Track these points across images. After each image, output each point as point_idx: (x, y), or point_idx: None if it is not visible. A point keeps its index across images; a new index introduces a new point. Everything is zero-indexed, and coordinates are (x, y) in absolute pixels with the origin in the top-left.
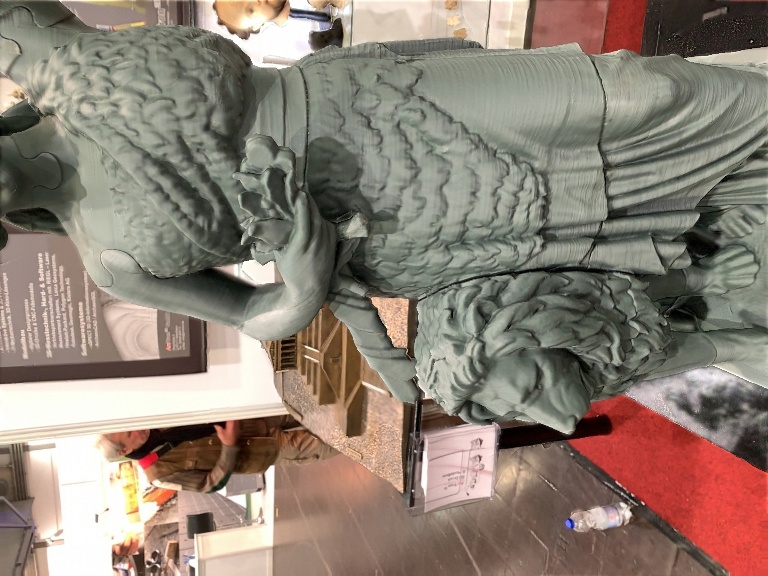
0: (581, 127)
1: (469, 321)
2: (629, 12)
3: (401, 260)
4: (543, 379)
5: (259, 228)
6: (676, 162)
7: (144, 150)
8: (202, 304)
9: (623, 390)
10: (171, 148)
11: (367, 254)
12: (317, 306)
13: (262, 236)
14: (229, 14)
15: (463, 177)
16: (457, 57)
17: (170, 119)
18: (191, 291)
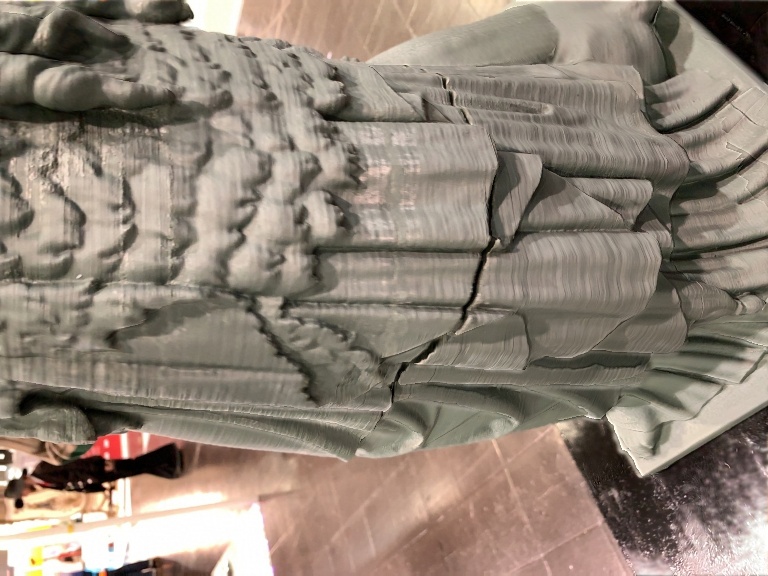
0: None
1: None
2: None
3: None
4: None
5: None
6: None
7: None
8: None
9: None
10: None
11: None
12: None
13: None
14: None
15: None
16: (205, 434)
17: None
18: None
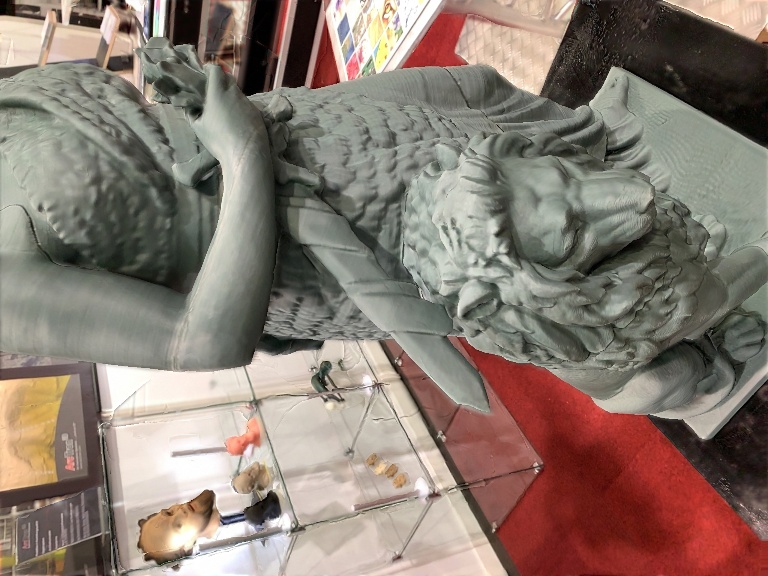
0: (441, 84)
1: (443, 150)
2: (515, 386)
3: (345, 161)
4: (569, 171)
5: (168, 64)
6: (543, 121)
7: (41, 87)
8: (123, 290)
9: (701, 262)
10: (70, 86)
11: (305, 160)
12: (265, 171)
13: (173, 75)
14: (156, 539)
15: (365, 106)
16: None
17: (69, 72)
18: (106, 276)
